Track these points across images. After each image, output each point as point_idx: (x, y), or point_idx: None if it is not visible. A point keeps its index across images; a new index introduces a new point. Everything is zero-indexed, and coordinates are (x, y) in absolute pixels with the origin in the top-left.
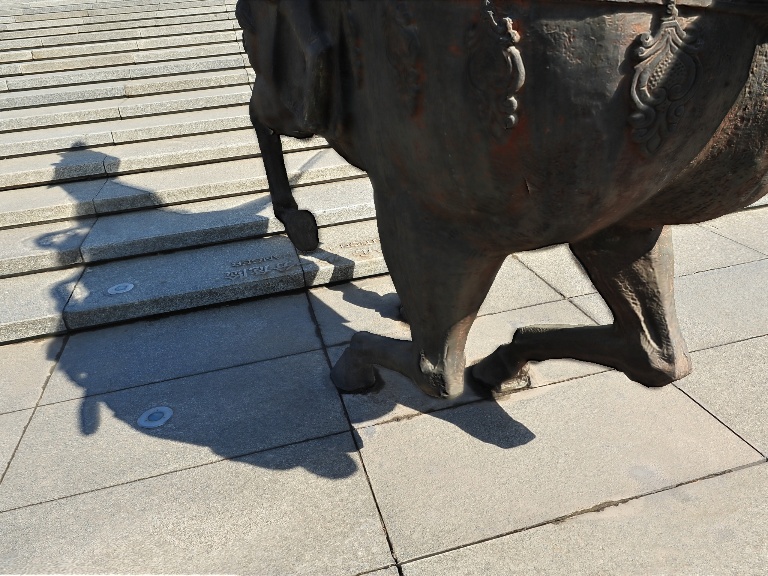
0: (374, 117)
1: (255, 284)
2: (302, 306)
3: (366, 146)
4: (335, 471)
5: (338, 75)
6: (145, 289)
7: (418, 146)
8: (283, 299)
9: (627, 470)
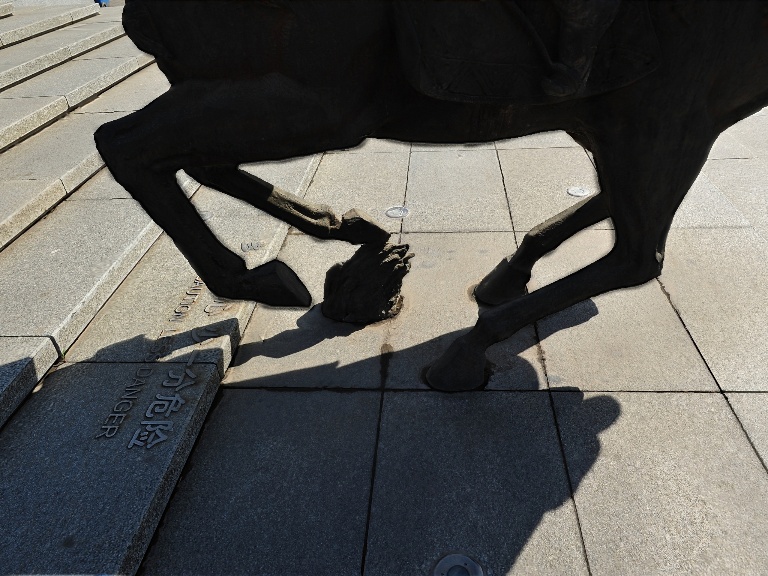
0: (710, 47)
1: (193, 420)
2: (262, 396)
3: (677, 80)
4: (609, 410)
5: (650, 20)
6: (69, 574)
7: (764, 56)
8: (222, 412)
9: None
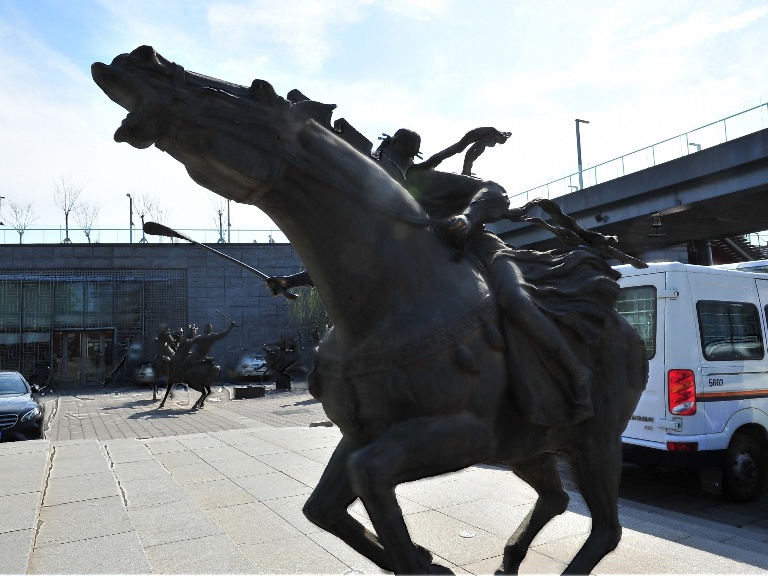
0: (619, 394)
1: None
2: None
3: None
4: None
5: None
6: None
7: None
8: None
9: (562, 570)
